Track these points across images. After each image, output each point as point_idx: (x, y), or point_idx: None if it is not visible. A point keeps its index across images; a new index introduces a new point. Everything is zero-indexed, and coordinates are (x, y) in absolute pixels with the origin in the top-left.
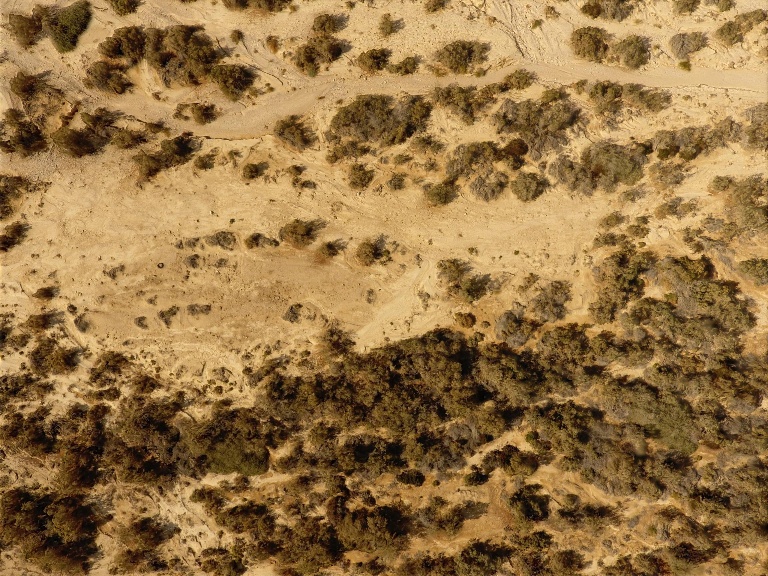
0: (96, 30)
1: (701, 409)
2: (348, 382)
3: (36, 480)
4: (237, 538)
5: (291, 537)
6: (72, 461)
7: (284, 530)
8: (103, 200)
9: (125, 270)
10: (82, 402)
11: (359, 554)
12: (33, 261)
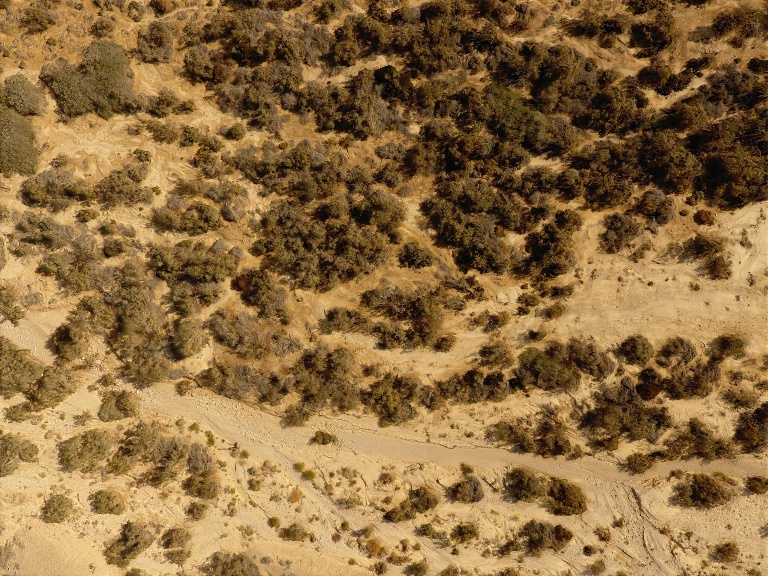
0: None
1: None
2: None
3: None
4: None
5: None
6: None
7: None
8: None
9: None
10: None
11: None
12: None
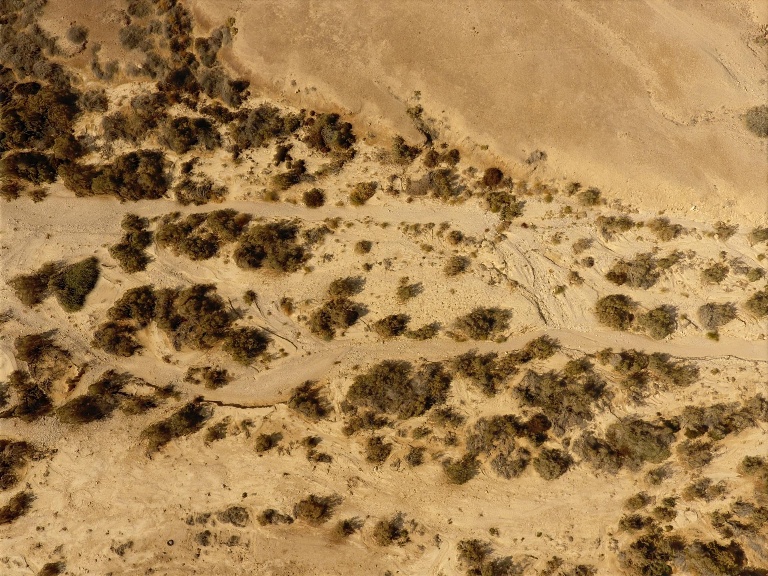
0: (104, 290)
1: None
2: None
3: None
4: None
5: None
6: None
7: None
8: (111, 470)
9: (133, 546)
10: None
11: None
12: (38, 534)
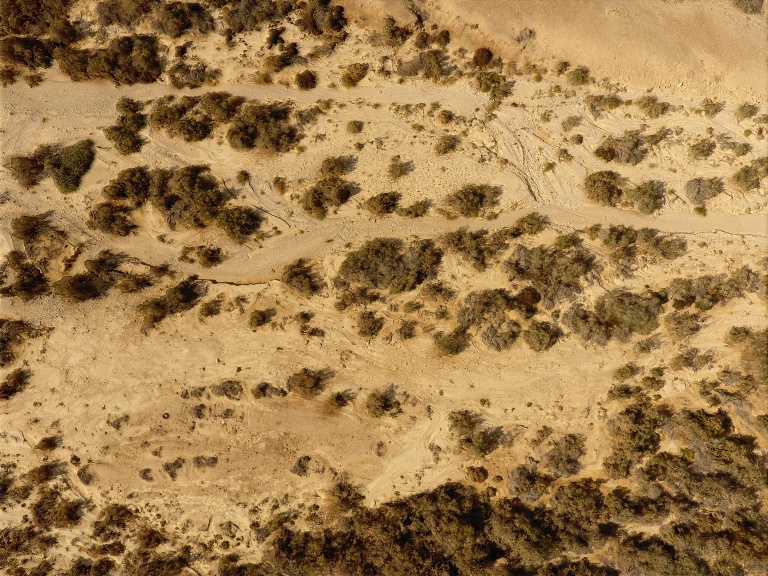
0: (99, 171)
1: (718, 570)
2: (358, 538)
3: None
4: None
5: None
6: None
7: None
8: (107, 347)
9: (129, 420)
10: (86, 556)
11: None
12: (35, 409)
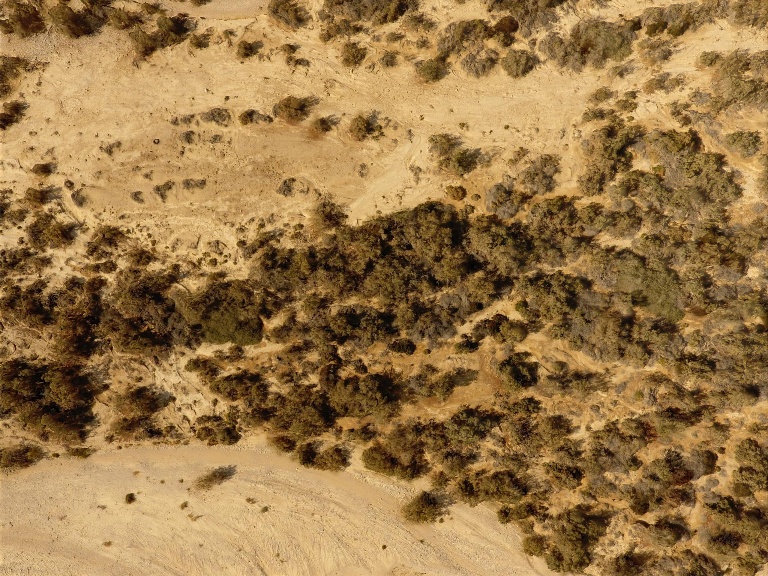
0: None
1: (688, 277)
2: (340, 253)
3: (34, 351)
4: (231, 406)
5: (284, 404)
6: (69, 328)
7: (277, 396)
8: (100, 79)
9: (121, 146)
10: (79, 275)
11: (351, 421)
12: (31, 138)
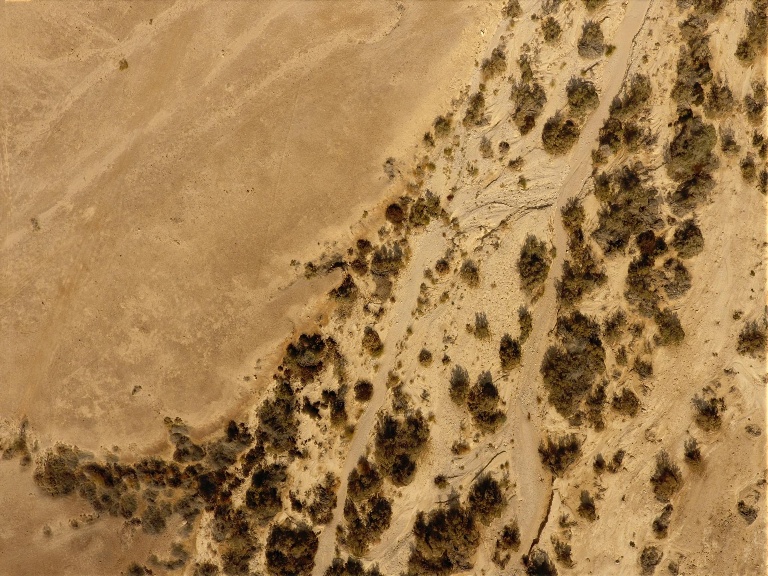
0: None
1: None
2: None
3: None
4: None
5: None
6: None
7: None
8: None
9: None
10: None
11: None
12: None
